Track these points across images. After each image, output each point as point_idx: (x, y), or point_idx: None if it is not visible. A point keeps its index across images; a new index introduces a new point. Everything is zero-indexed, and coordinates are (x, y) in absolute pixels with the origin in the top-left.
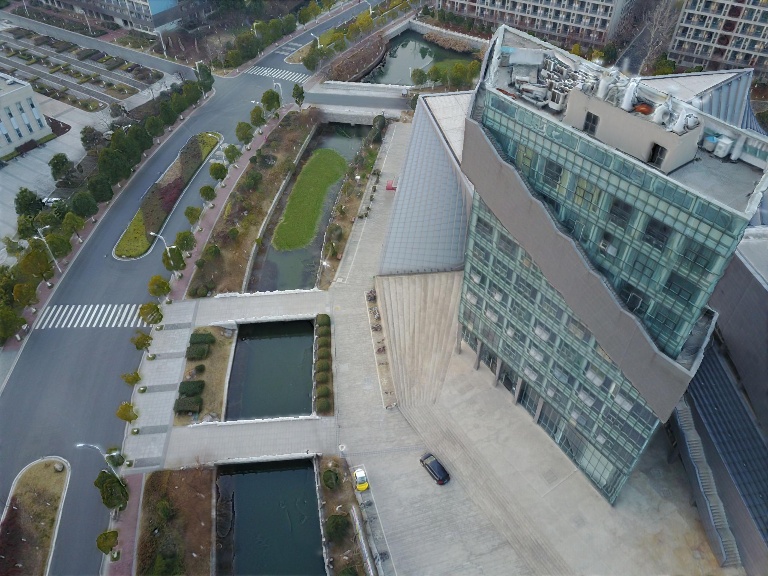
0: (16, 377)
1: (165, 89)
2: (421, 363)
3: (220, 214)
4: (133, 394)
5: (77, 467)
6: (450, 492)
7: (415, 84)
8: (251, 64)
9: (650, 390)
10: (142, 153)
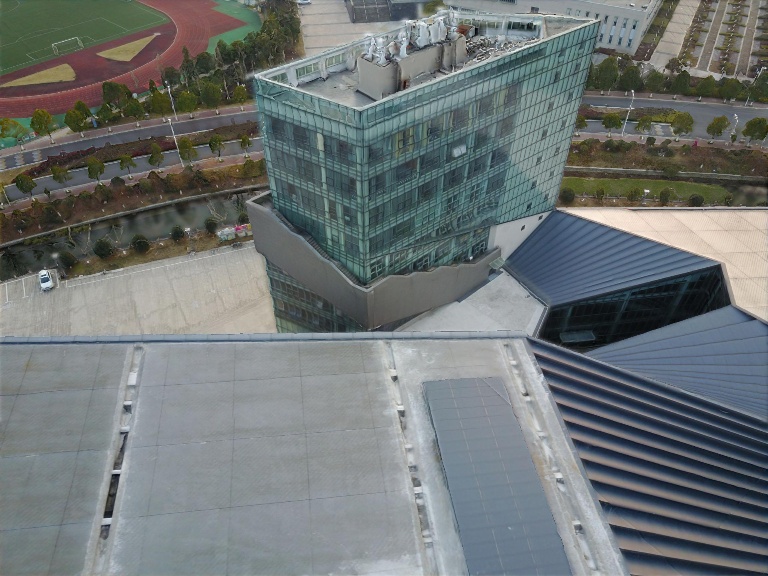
0: None
1: None
2: None
3: None
4: None
5: None
6: None
7: None
8: None
9: None
10: (626, 91)
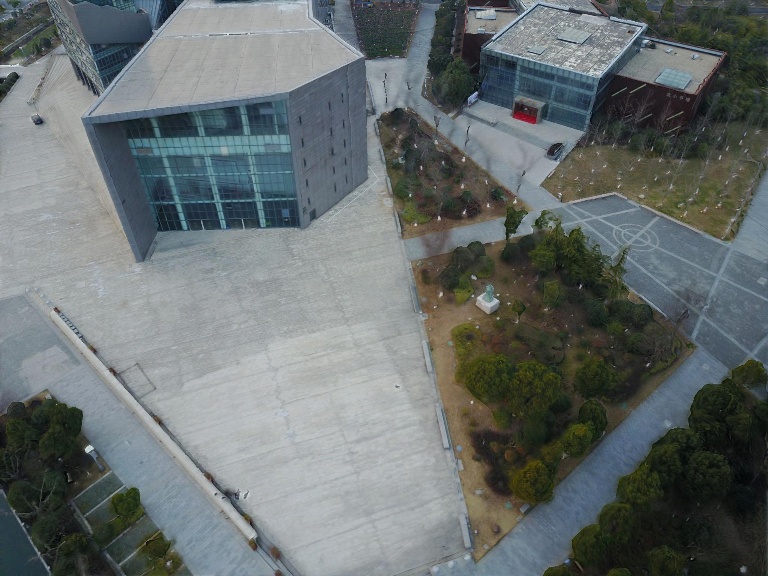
0: None
1: None
2: (56, 86)
3: None
4: None
5: None
6: (40, 127)
7: None
8: None
9: (76, 26)
10: None
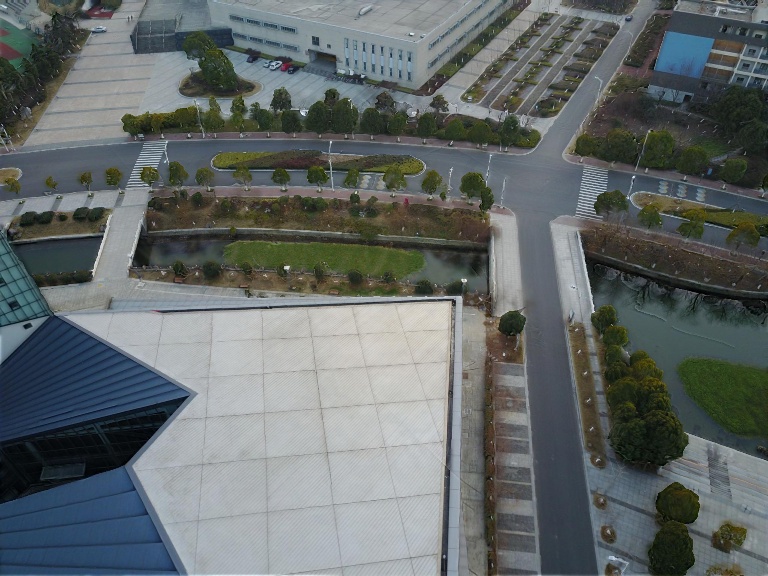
0: (99, 147)
1: (497, 119)
2: None
3: (270, 197)
4: (57, 194)
5: (6, 186)
6: None
7: (592, 322)
8: (611, 167)
9: None
10: (371, 134)
